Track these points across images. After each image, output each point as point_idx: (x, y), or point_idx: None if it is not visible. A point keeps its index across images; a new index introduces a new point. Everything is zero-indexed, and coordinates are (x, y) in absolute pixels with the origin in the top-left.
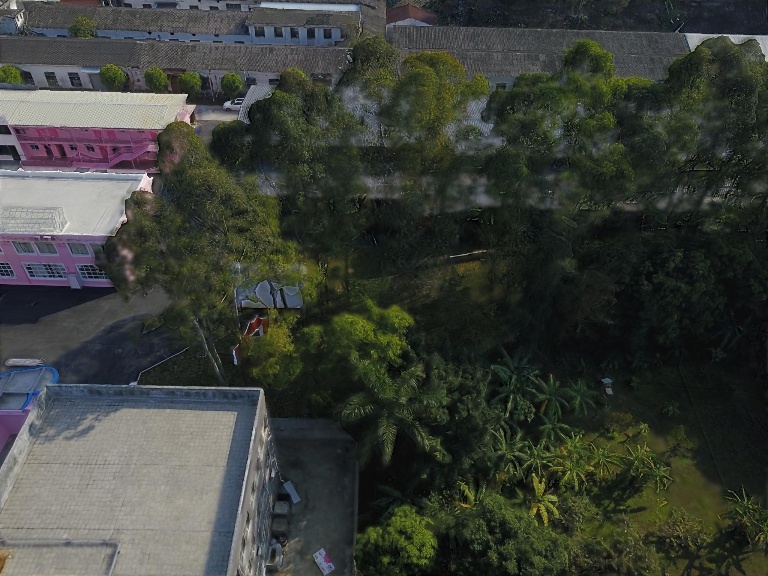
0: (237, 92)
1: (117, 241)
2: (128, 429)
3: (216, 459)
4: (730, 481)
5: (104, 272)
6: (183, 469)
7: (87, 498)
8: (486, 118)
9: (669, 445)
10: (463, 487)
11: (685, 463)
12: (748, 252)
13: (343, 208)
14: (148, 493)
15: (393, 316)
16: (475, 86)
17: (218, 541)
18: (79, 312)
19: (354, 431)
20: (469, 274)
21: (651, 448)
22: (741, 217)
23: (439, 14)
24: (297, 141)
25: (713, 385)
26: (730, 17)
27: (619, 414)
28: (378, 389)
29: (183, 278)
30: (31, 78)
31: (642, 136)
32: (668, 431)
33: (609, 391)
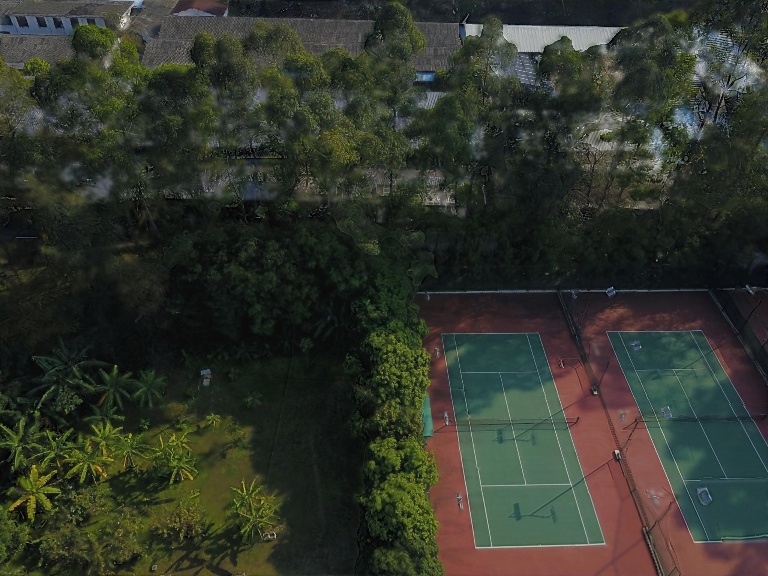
0: None
1: None
2: None
3: None
4: (276, 472)
5: None
6: None
7: None
8: None
9: None
10: None
11: (241, 454)
12: (325, 241)
13: None
14: None
15: None
16: None
17: None
18: None
19: None
20: None
21: (215, 439)
22: (307, 205)
23: (236, 4)
24: None
25: (317, 376)
26: (528, 8)
27: (174, 405)
28: None
29: None
30: None
31: None
32: (242, 422)
33: (206, 382)
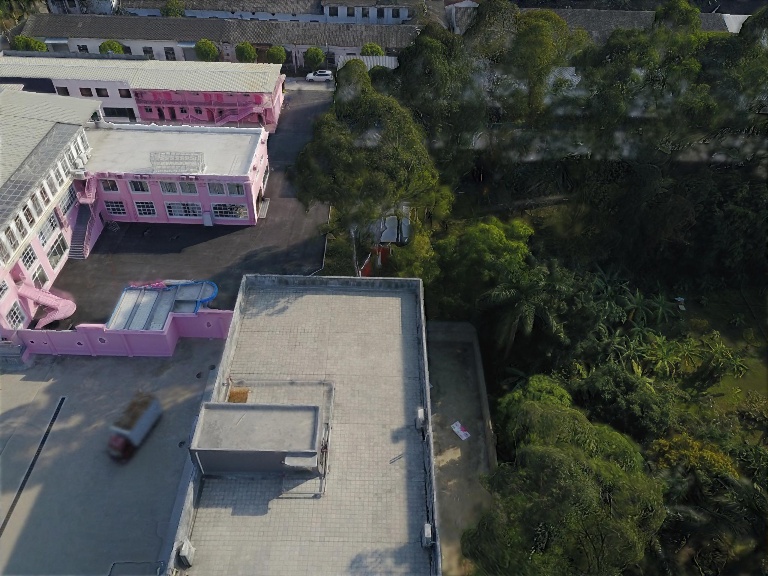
0: (319, 65)
1: (310, 154)
2: (316, 309)
3: (392, 329)
4: None
5: (234, 211)
6: (368, 336)
7: (298, 354)
8: (581, 69)
9: (738, 348)
10: (578, 367)
11: (753, 362)
12: None
13: (466, 142)
14: (345, 351)
15: (519, 226)
16: (579, 39)
17: (409, 383)
18: (215, 244)
19: (483, 325)
20: (549, 216)
21: None
22: None
23: None
24: (443, 79)
25: None
26: None
27: (697, 320)
28: (519, 276)
29: (358, 187)
30: (130, 52)
31: (722, 79)
32: (736, 338)
33: (682, 308)
